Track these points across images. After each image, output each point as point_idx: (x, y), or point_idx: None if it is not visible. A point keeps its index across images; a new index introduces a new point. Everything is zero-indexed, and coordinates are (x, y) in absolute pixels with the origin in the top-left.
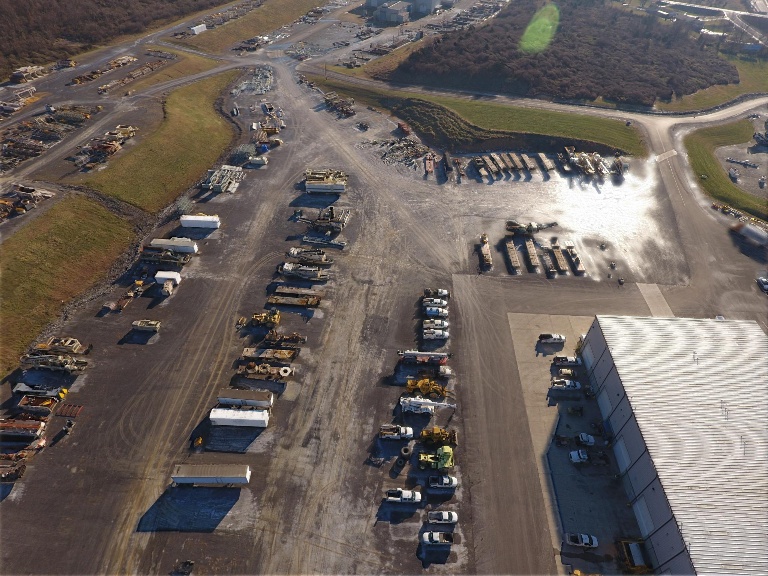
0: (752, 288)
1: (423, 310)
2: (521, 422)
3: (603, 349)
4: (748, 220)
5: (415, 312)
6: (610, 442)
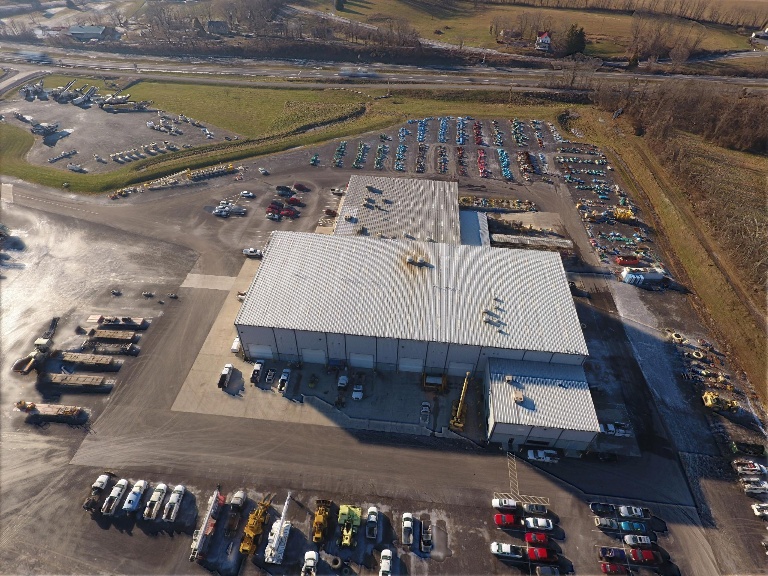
0: (221, 221)
1: (120, 517)
2: (315, 431)
3: (271, 333)
4: (144, 188)
5: (118, 529)
6: (347, 366)
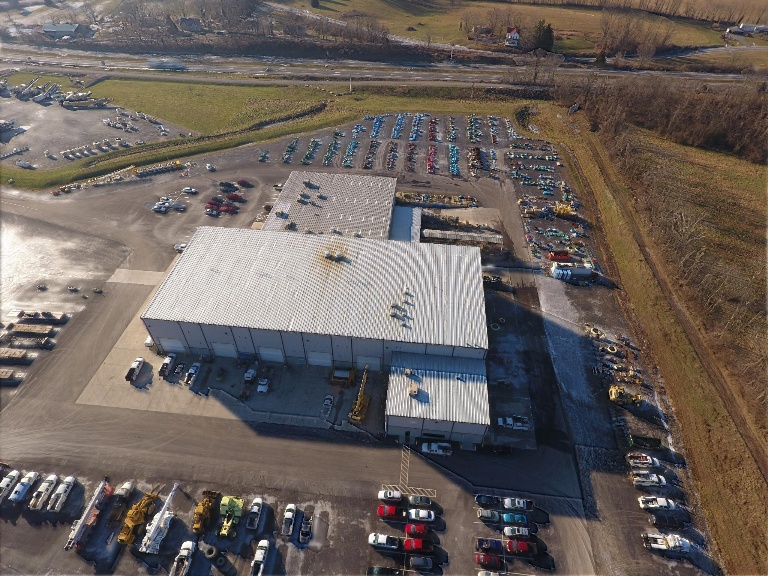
0: (159, 217)
1: (7, 507)
2: (215, 424)
3: (178, 327)
4: (88, 184)
5: (3, 519)
6: (257, 360)
